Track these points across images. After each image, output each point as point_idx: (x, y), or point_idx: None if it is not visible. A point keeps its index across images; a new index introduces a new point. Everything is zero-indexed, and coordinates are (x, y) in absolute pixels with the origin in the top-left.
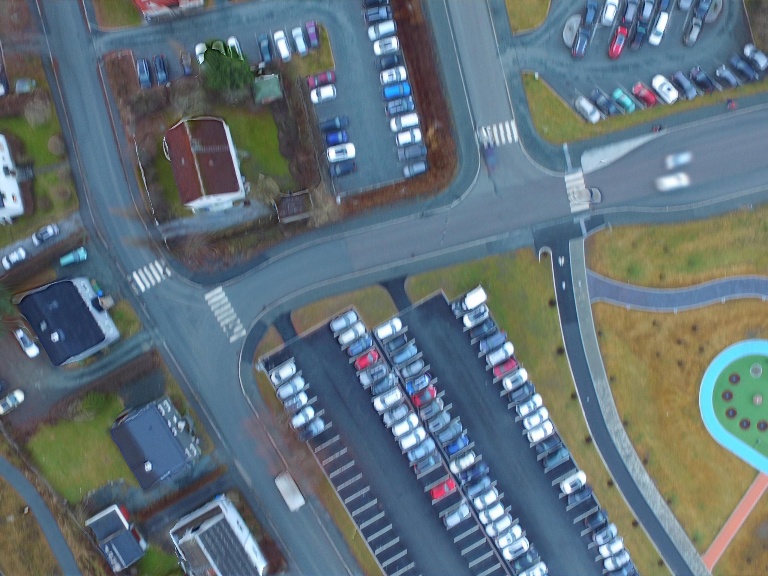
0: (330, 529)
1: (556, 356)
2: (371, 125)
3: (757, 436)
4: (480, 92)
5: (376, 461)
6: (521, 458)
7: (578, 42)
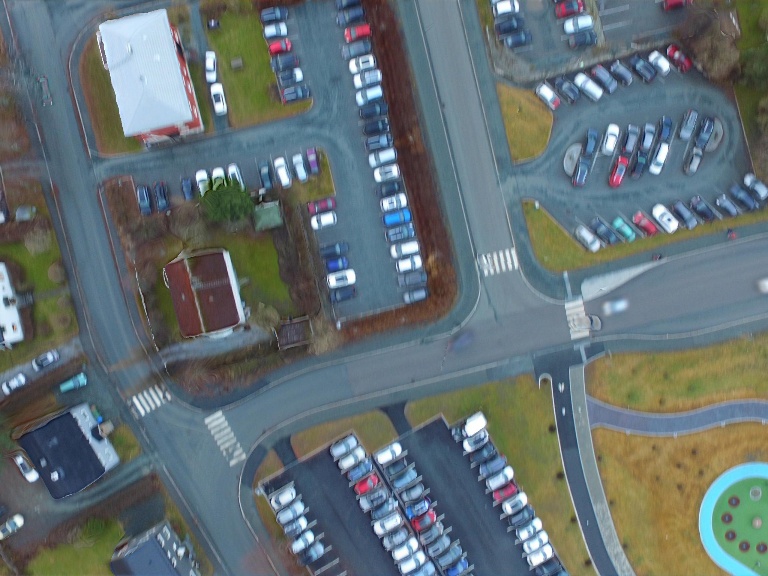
0: None
1: (556, 481)
2: (371, 250)
3: (756, 558)
4: (480, 220)
5: None
6: None
7: (578, 172)
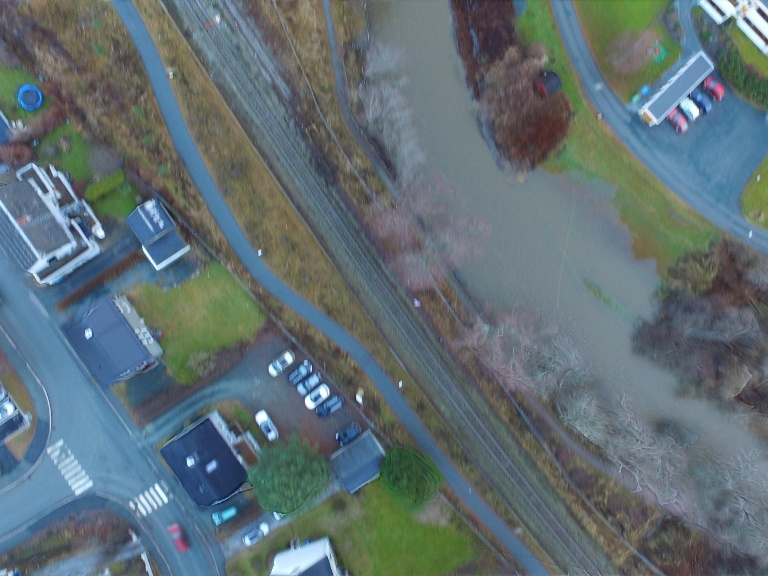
0: None
1: None
2: None
3: None
4: None
5: None
6: None
7: None
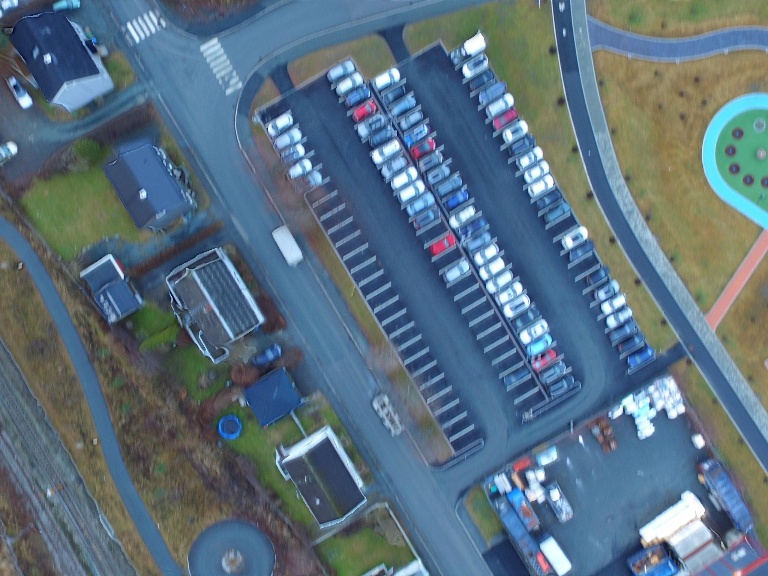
0: (328, 287)
1: (557, 107)
2: None
3: (761, 192)
4: None
5: (375, 217)
6: (522, 214)
7: None
